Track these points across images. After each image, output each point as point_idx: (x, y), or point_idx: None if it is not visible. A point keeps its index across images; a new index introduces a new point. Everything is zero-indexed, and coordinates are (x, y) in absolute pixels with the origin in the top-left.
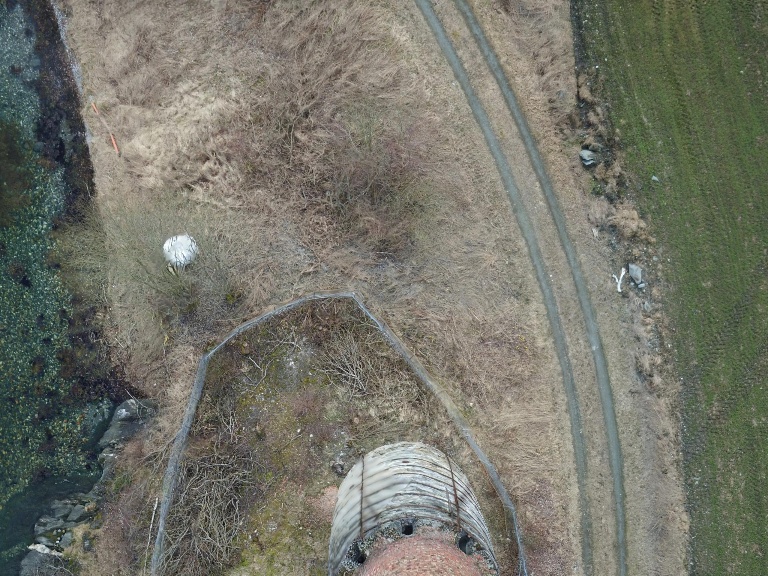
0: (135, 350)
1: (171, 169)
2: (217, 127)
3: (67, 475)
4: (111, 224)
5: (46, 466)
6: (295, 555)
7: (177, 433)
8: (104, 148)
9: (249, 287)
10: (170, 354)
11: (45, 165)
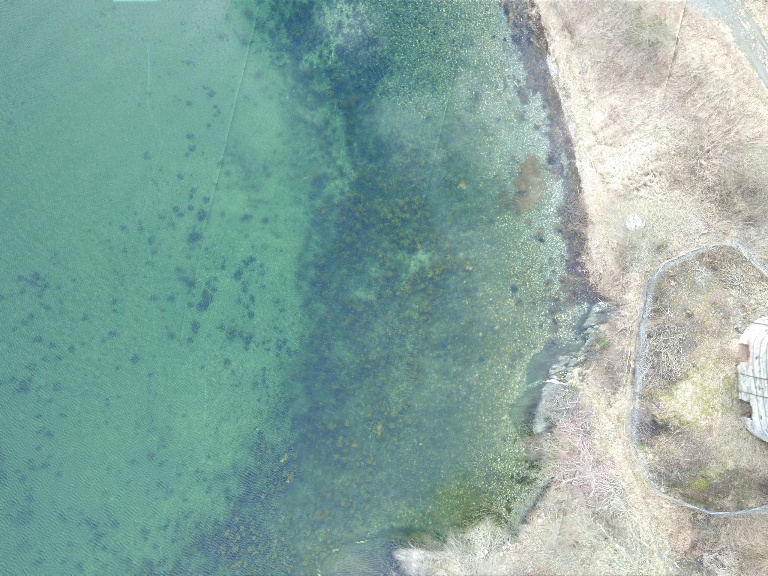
0: (605, 276)
1: (628, 179)
2: (655, 157)
3: (564, 343)
4: (592, 209)
5: (553, 339)
6: (715, 373)
7: (636, 317)
8: (588, 168)
9: (671, 241)
10: (625, 277)
11: (554, 177)
